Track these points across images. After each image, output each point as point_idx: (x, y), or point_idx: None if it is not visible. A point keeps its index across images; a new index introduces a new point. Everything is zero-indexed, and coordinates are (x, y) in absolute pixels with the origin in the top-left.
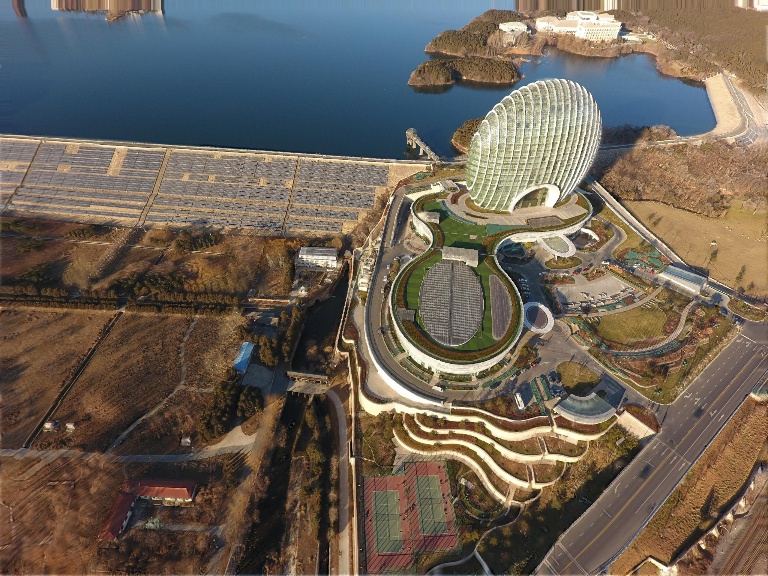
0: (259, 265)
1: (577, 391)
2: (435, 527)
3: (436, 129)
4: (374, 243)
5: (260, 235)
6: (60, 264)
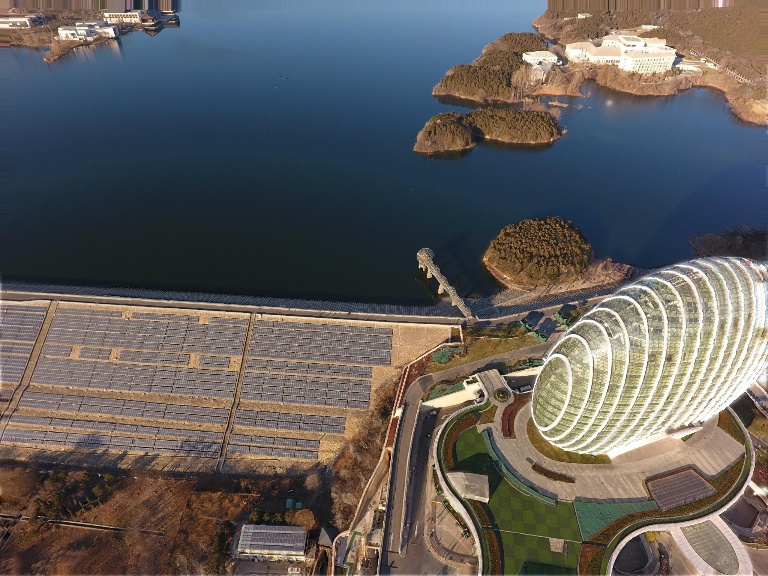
0: (165, 574)
1: None
2: None
3: (458, 235)
4: (371, 512)
5: (183, 470)
6: None
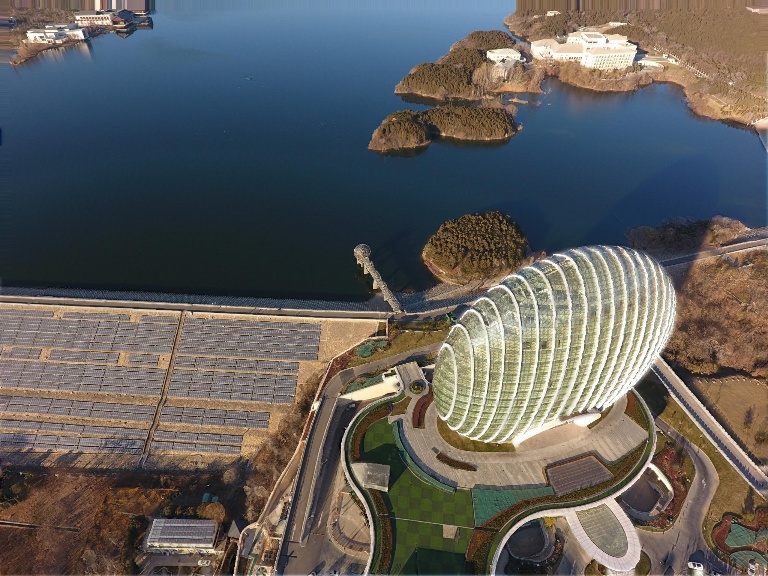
0: (73, 569)
1: None
2: None
3: None
4: (282, 504)
5: (105, 467)
6: None
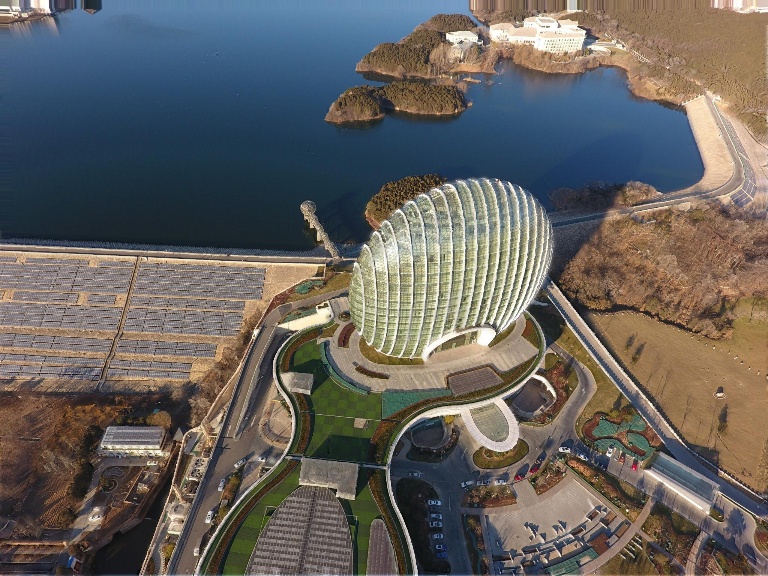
0: (34, 467)
1: None
2: None
3: (348, 193)
4: (222, 414)
5: (65, 391)
6: None
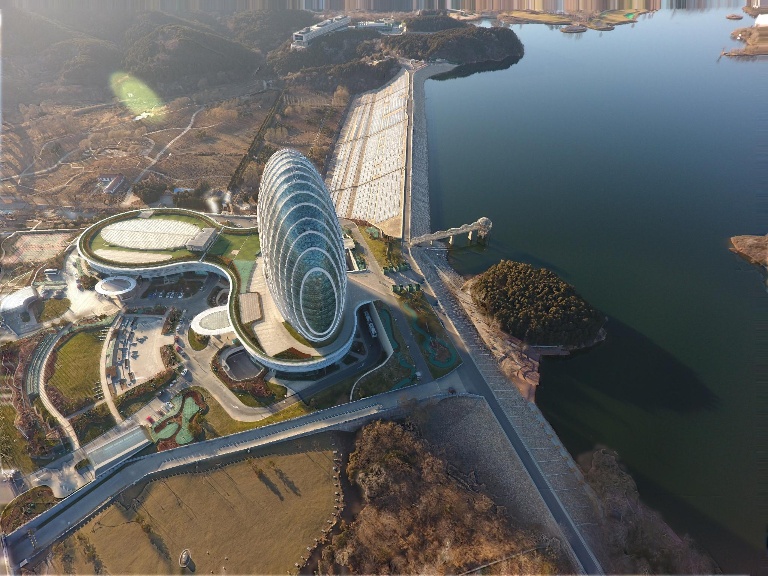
0: None
1: (39, 305)
2: (25, 255)
3: None
4: None
5: None
6: (296, 132)
